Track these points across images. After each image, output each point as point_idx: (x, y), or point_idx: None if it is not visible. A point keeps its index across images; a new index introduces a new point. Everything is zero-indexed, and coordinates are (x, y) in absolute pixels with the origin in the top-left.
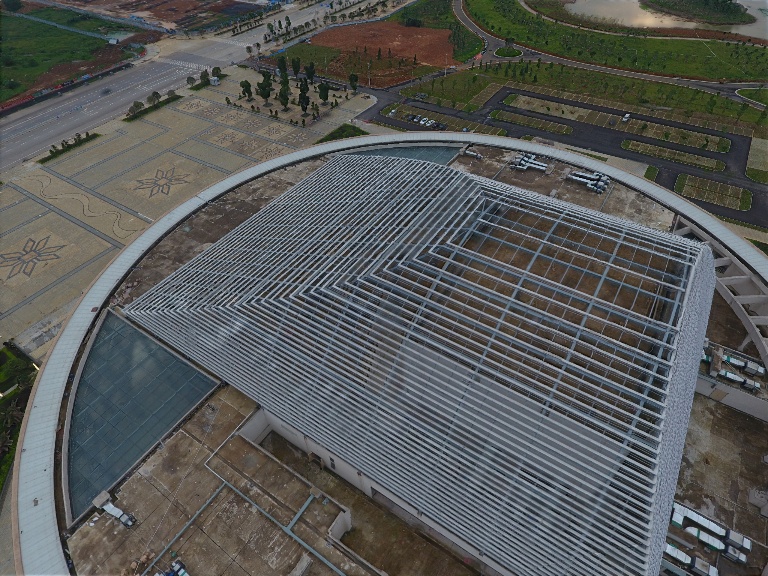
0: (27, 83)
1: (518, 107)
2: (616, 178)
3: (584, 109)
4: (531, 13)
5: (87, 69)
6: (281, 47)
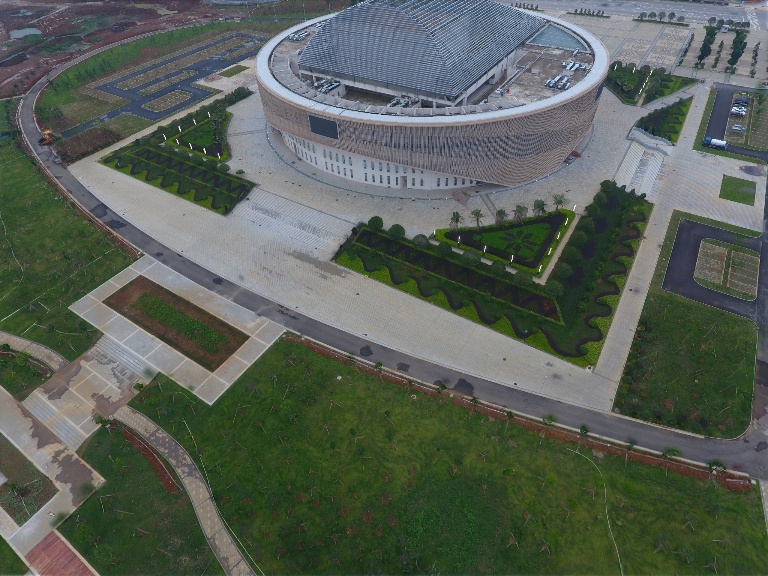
0: None
1: None
2: None
3: None
4: None
5: None
6: None
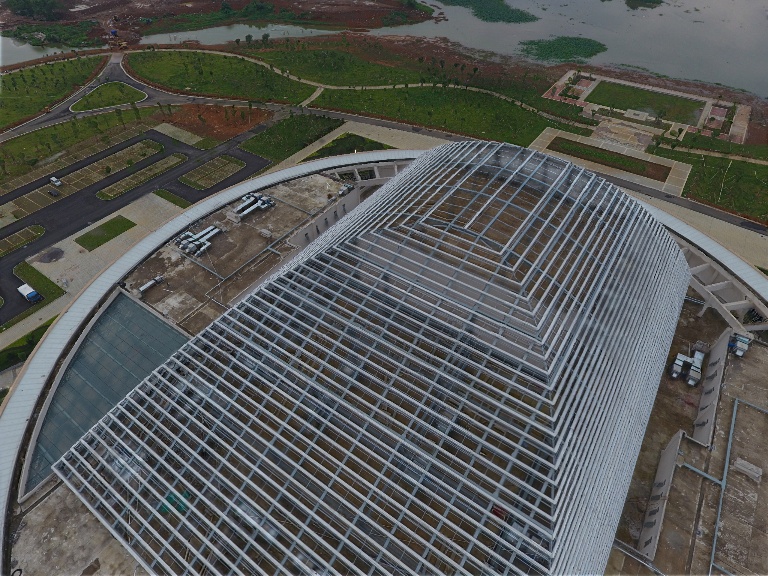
0: None
1: None
2: (256, 189)
3: (2, 206)
4: None
5: None
6: None
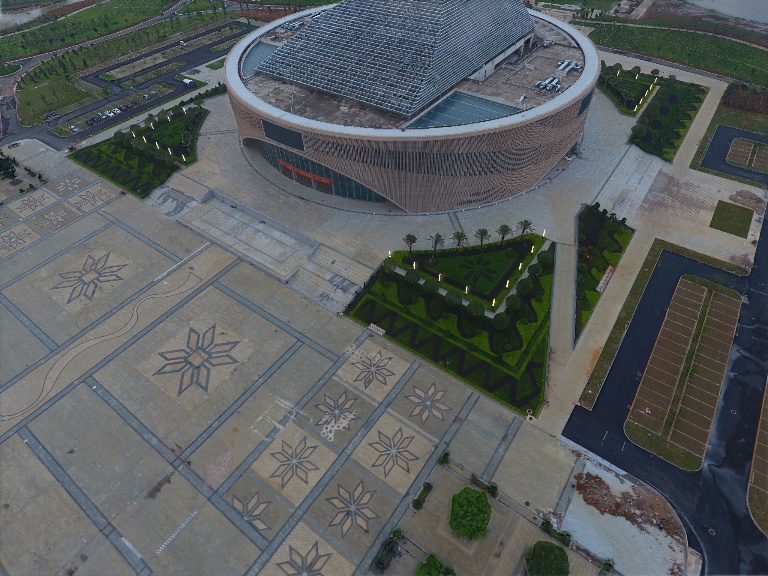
0: None
1: (125, 76)
2: None
3: (155, 55)
4: None
5: None
6: None
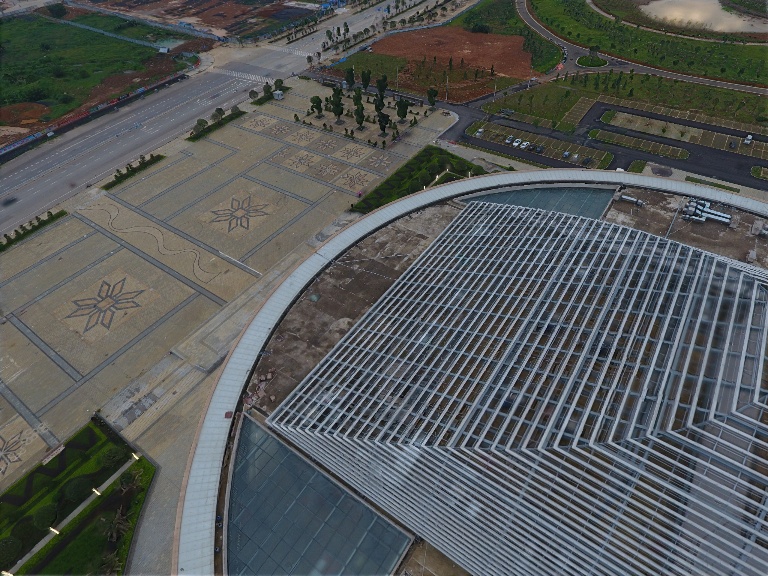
0: (81, 97)
1: (619, 126)
2: None
3: (695, 129)
4: (605, 17)
5: (141, 81)
6: (341, 56)
